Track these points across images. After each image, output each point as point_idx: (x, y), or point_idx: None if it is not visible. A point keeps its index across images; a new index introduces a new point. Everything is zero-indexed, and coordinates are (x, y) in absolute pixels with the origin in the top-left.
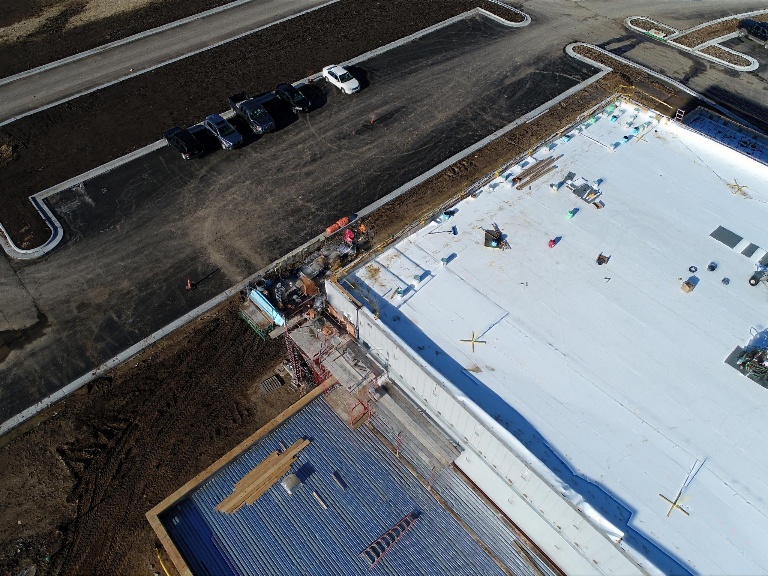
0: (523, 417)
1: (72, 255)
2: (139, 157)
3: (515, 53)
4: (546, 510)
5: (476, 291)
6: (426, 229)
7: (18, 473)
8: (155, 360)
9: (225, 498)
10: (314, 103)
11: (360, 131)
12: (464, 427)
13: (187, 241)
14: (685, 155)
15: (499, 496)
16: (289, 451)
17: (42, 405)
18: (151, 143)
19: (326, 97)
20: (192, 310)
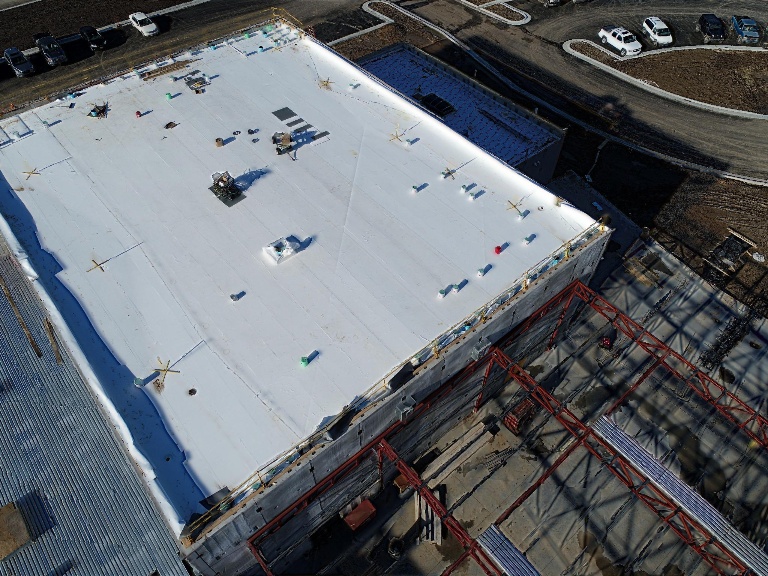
0: (32, 217)
1: None
2: None
3: (315, 7)
4: None
5: (58, 143)
6: (50, 104)
7: None
8: None
9: None
10: (113, 43)
11: None
12: None
13: None
14: (304, 61)
15: None
16: None
17: None
18: None
19: (126, 39)
20: None
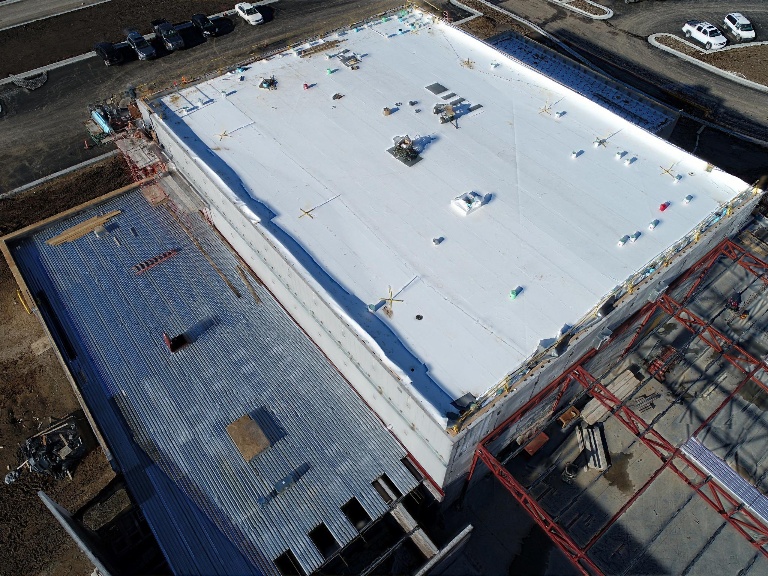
0: (235, 172)
1: (5, 125)
2: (72, 63)
3: None
4: None
5: (239, 111)
6: (222, 77)
7: None
8: (49, 189)
9: (53, 237)
10: (223, 31)
11: (254, 51)
12: (201, 182)
13: None
14: (441, 43)
15: (230, 236)
16: (105, 215)
17: None
18: (83, 54)
19: (234, 27)
20: (85, 161)
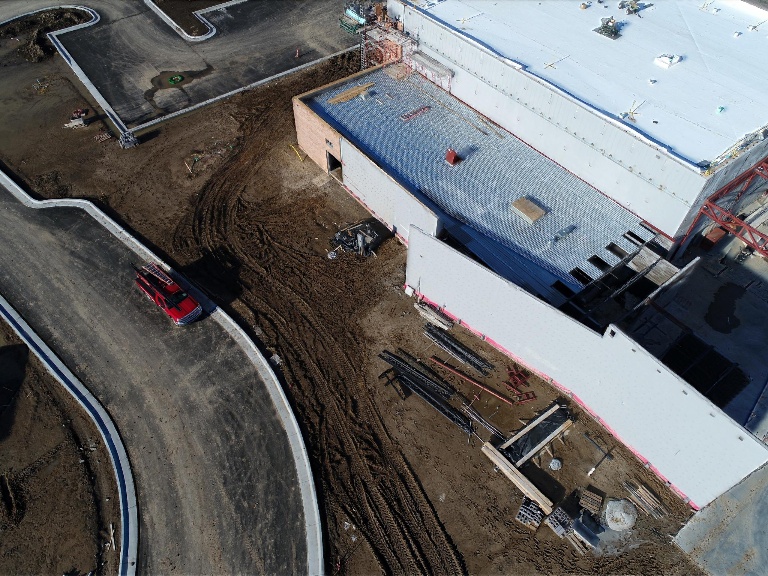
0: (484, 42)
1: (223, 41)
2: None
3: None
4: (491, 78)
5: (468, 6)
6: None
7: (209, 121)
8: (279, 84)
9: (331, 98)
10: None
11: None
12: (455, 52)
13: (294, 37)
14: None
15: (471, 95)
16: (364, 85)
17: (217, 98)
18: None
19: None
20: (299, 66)
